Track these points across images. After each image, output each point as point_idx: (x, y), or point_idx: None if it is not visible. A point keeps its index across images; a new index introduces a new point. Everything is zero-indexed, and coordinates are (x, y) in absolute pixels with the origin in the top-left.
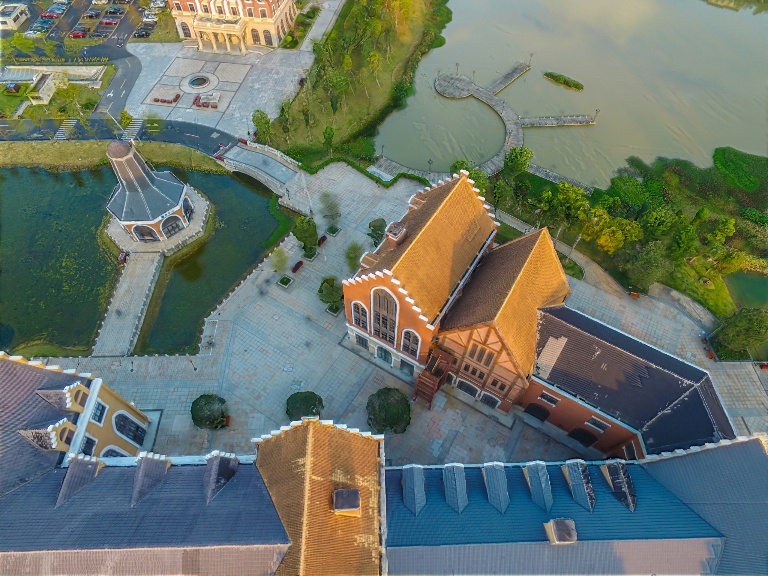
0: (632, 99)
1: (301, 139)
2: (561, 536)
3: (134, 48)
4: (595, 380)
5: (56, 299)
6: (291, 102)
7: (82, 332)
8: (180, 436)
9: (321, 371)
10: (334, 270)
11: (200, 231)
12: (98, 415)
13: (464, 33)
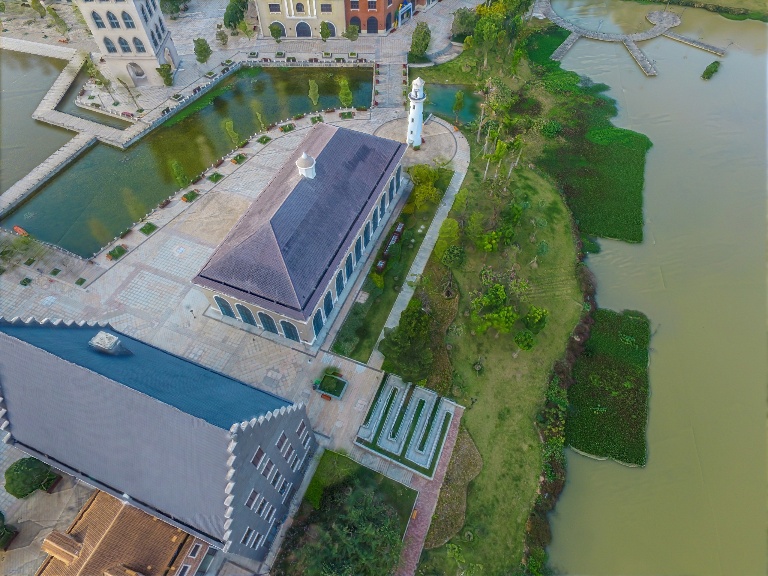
0: (705, 103)
1: None
2: None
3: None
4: None
5: None
6: None
7: None
8: None
9: None
10: None
11: None
12: None
13: (762, 29)
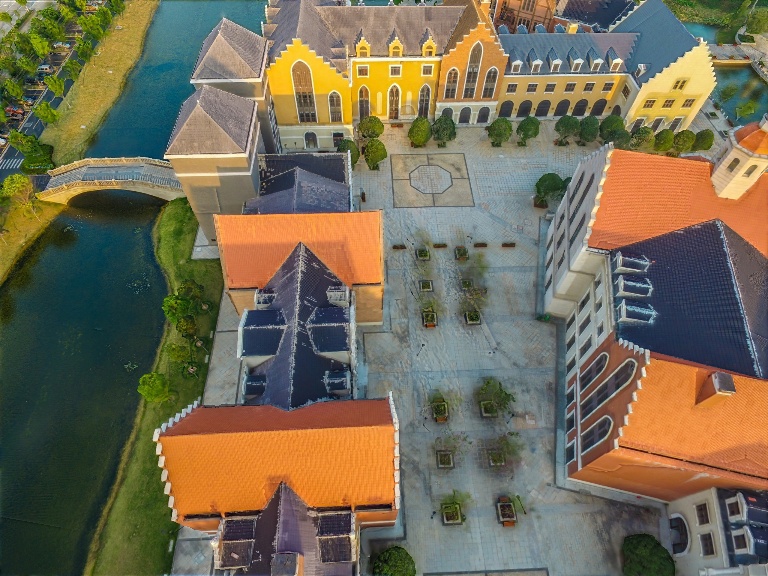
0: None
1: None
2: (572, 22)
3: None
4: (585, 10)
5: None
6: None
7: None
8: None
9: None
10: None
11: None
12: None
13: None
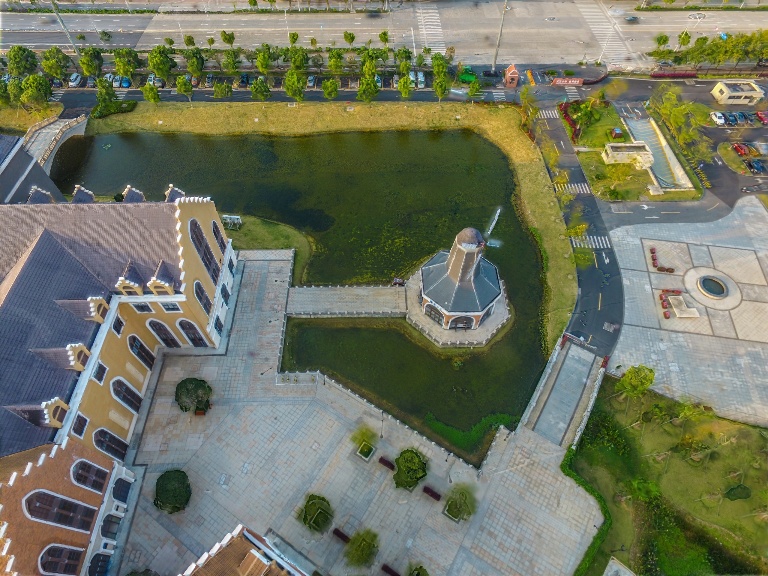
0: None
1: (652, 444)
2: None
3: (749, 204)
4: None
5: (358, 247)
6: (727, 418)
7: (322, 275)
8: (197, 375)
9: (237, 508)
10: (383, 516)
11: (439, 343)
12: (170, 307)
13: None
